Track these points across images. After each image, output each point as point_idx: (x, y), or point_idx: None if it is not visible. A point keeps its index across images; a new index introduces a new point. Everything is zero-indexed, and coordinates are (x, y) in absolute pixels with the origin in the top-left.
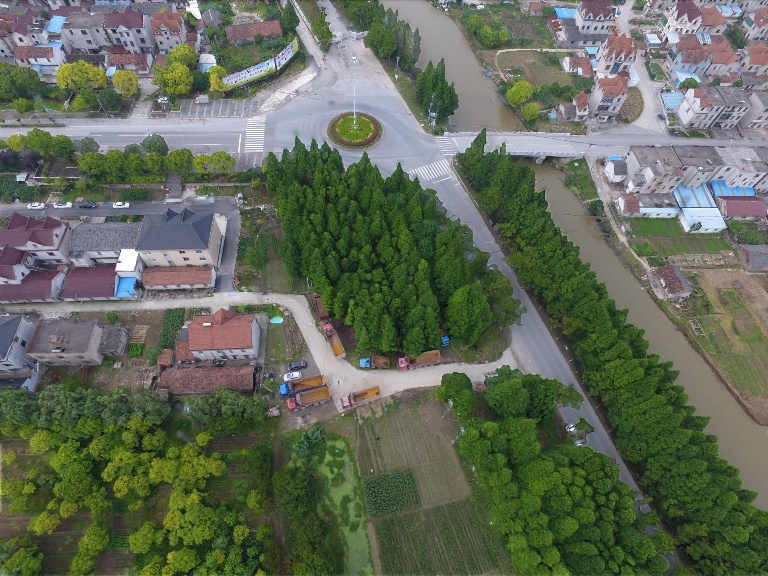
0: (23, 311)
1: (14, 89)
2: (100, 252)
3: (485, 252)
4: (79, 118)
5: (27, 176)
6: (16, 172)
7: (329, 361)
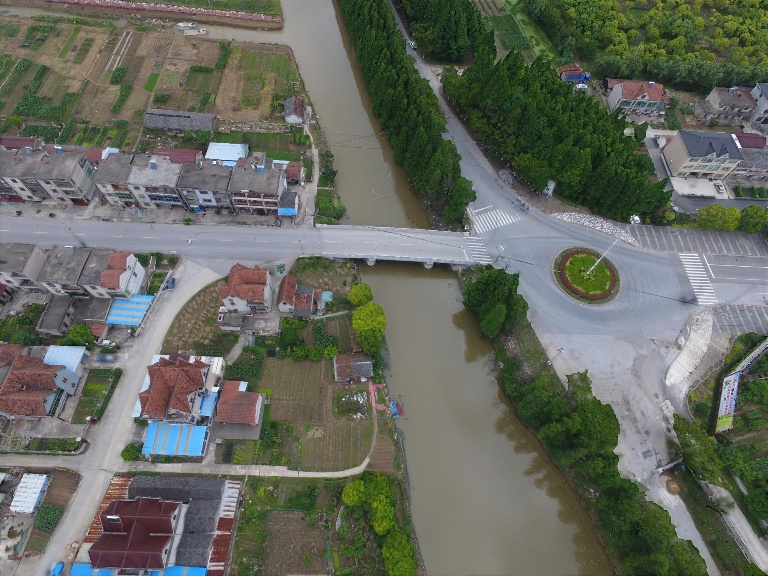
0: None
1: None
2: None
3: (465, 102)
4: None
5: None
6: None
7: None
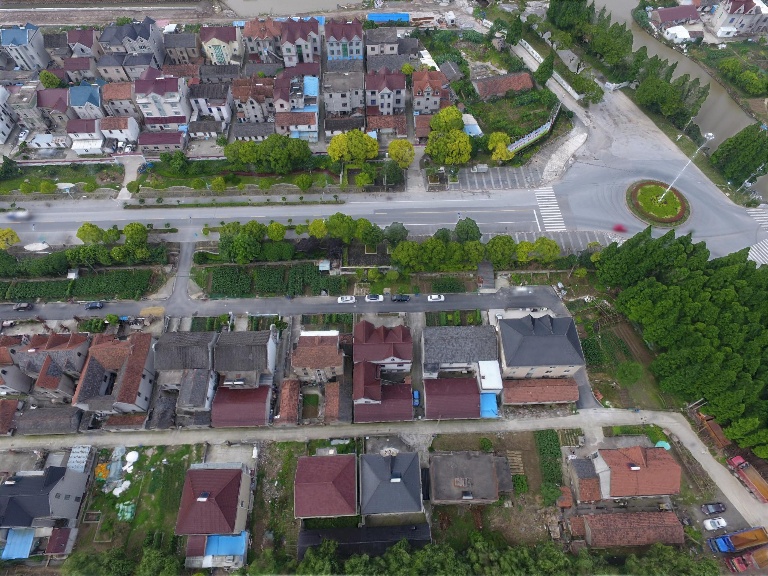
0: (380, 432)
1: (289, 163)
2: (452, 363)
3: None
4: (356, 192)
5: (330, 265)
6: (314, 259)
7: (748, 503)
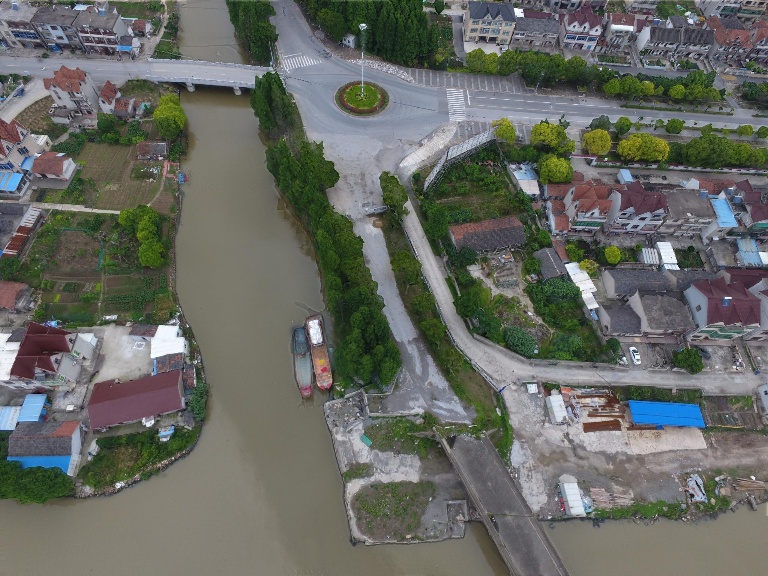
0: None
1: None
2: None
3: None
4: None
5: None
6: None
7: None
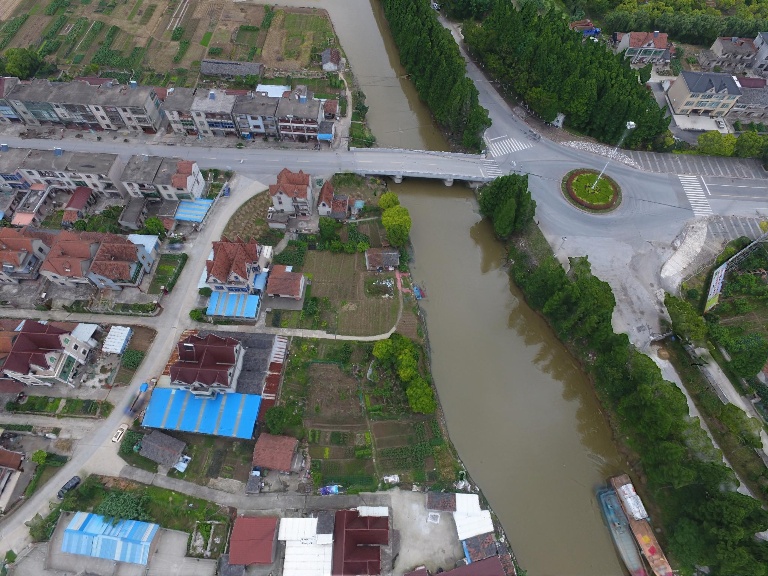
0: None
1: None
2: None
3: (483, 47)
4: None
5: None
6: None
7: None
